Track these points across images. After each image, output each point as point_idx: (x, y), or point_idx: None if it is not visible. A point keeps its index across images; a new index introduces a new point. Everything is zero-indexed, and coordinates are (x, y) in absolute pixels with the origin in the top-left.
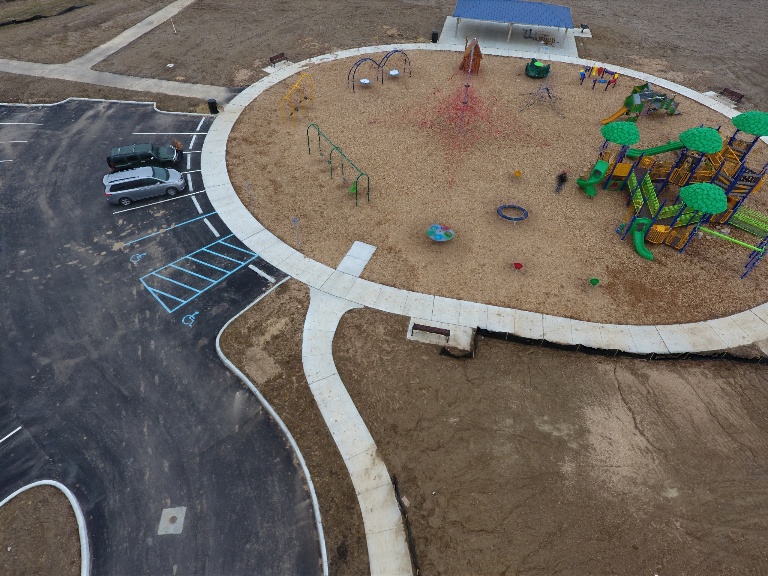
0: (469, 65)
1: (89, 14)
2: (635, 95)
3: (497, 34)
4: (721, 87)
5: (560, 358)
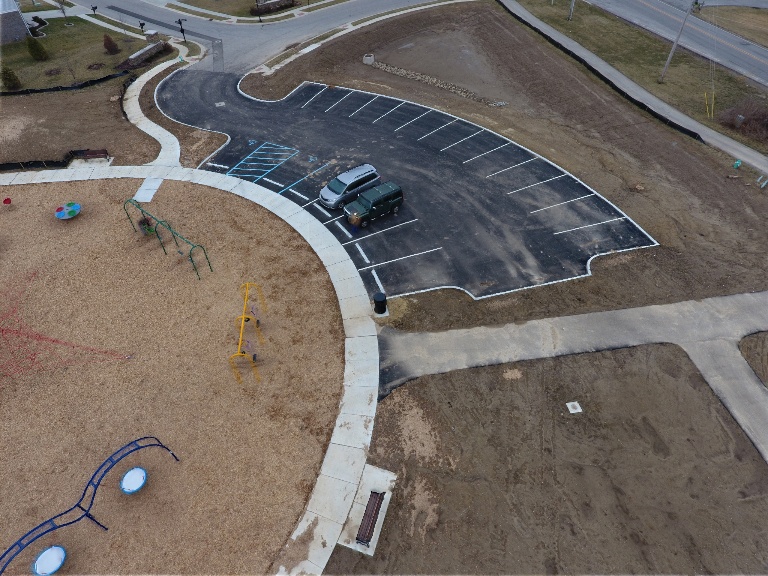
0: None
1: None
2: None
3: None
4: None
5: None
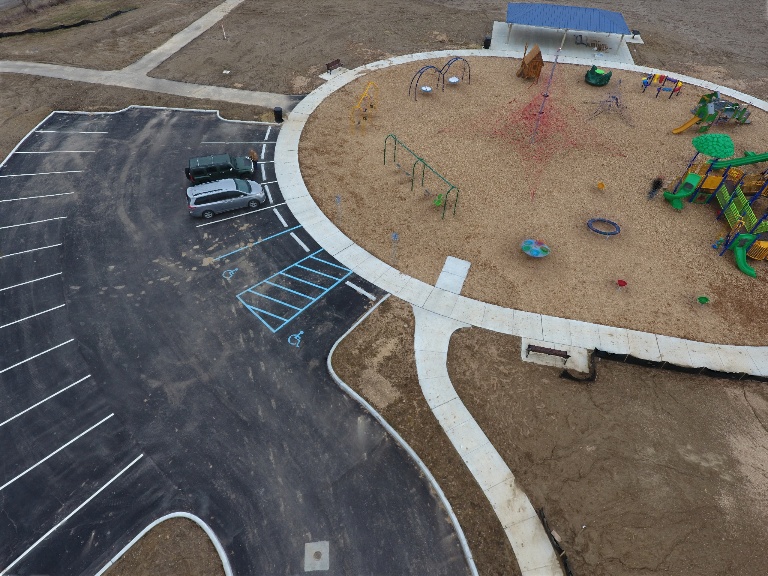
0: (529, 72)
1: (135, 19)
2: (709, 104)
3: (548, 40)
4: None
5: (684, 381)
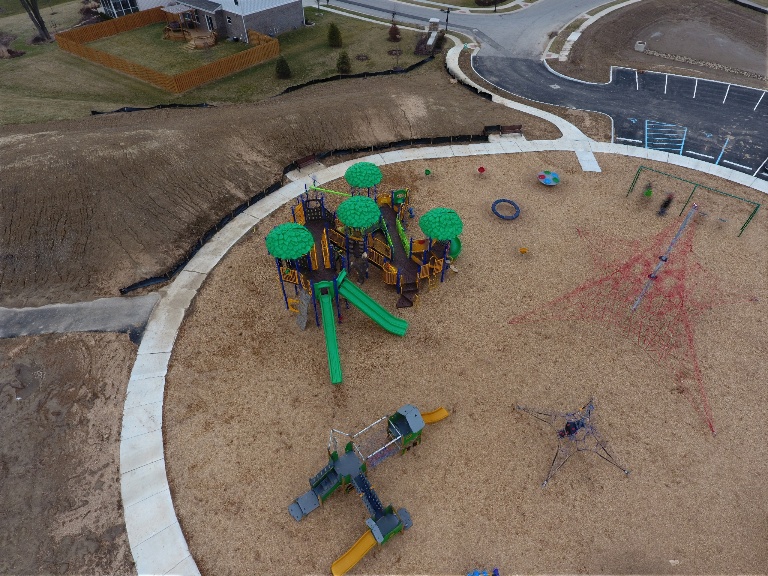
0: None
1: None
2: (412, 409)
3: None
4: None
5: None
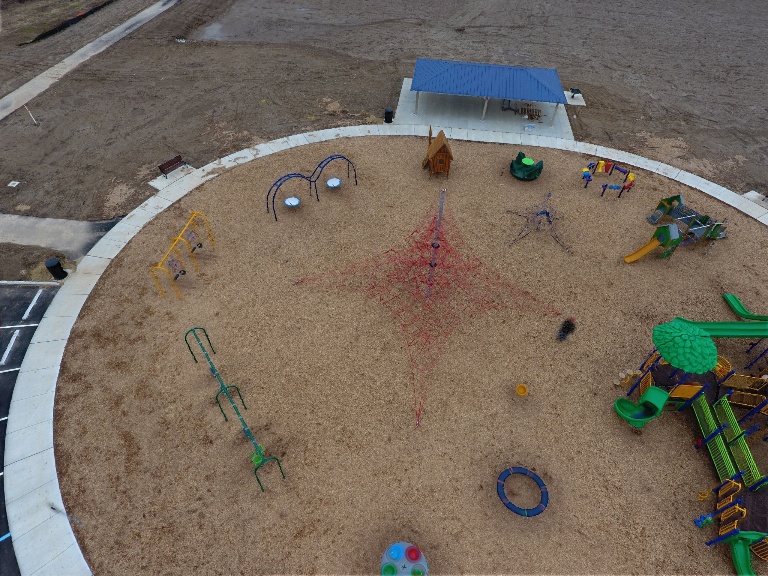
0: (435, 167)
1: None
2: (671, 226)
3: (468, 105)
4: (763, 183)
5: None
